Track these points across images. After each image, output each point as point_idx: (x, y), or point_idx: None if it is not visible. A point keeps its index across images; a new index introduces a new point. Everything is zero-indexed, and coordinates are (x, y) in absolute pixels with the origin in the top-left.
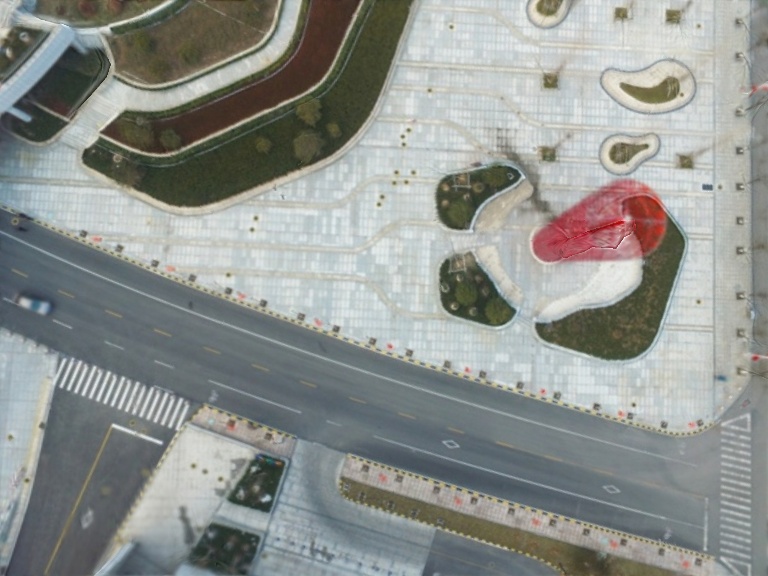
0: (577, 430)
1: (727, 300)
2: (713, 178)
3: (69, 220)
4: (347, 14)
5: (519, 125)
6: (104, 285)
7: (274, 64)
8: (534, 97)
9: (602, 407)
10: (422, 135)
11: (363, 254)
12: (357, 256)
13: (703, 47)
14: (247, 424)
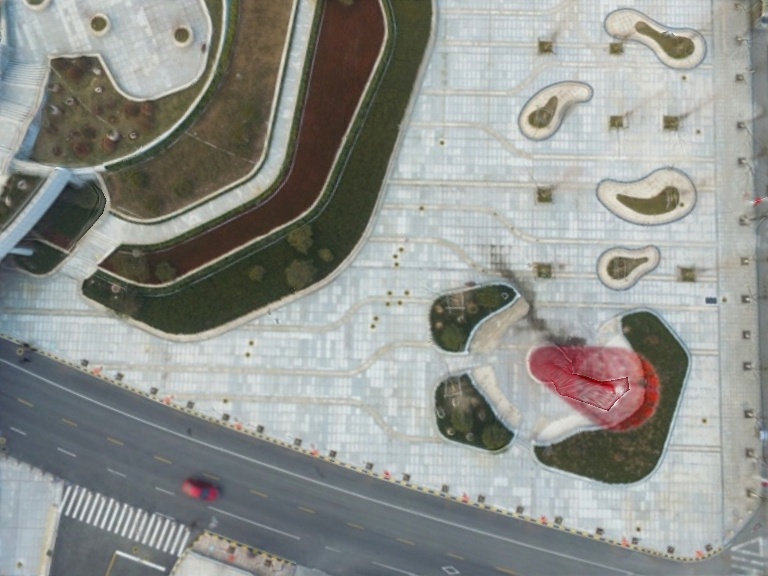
0: (580, 555)
1: (735, 418)
2: (717, 291)
3: (71, 350)
4: (336, 138)
5: (513, 241)
6: (105, 413)
7: (265, 192)
8: (528, 212)
9: (605, 532)
10: (415, 254)
11: (358, 377)
12: (352, 379)
13: (703, 154)
14: (247, 551)
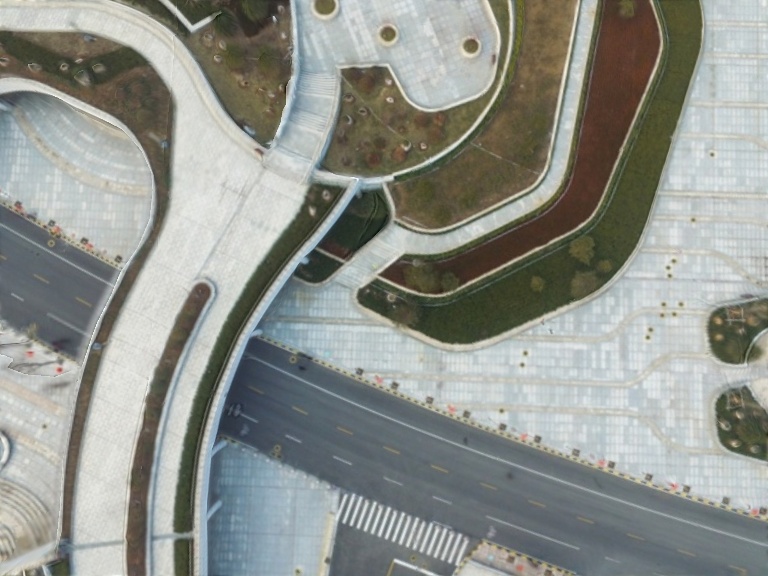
0: None
1: None
2: None
3: (345, 358)
4: (614, 149)
5: None
6: (381, 422)
7: (546, 203)
8: None
9: None
10: (688, 266)
11: (634, 388)
12: (629, 390)
13: None
14: (527, 561)
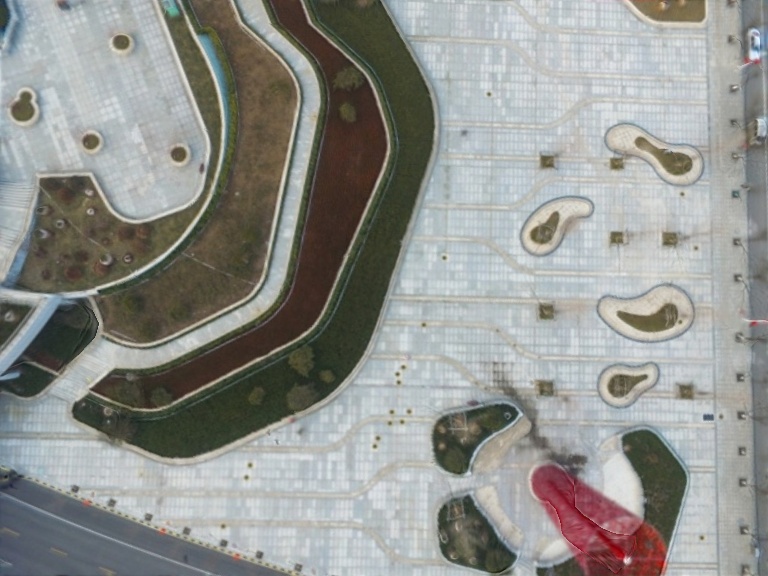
0: None
1: (731, 535)
2: (714, 407)
3: (60, 475)
4: (338, 256)
5: (515, 358)
6: (97, 541)
7: (265, 313)
8: (530, 328)
9: None
10: (417, 372)
11: (360, 499)
12: (354, 502)
13: (701, 270)
14: None
